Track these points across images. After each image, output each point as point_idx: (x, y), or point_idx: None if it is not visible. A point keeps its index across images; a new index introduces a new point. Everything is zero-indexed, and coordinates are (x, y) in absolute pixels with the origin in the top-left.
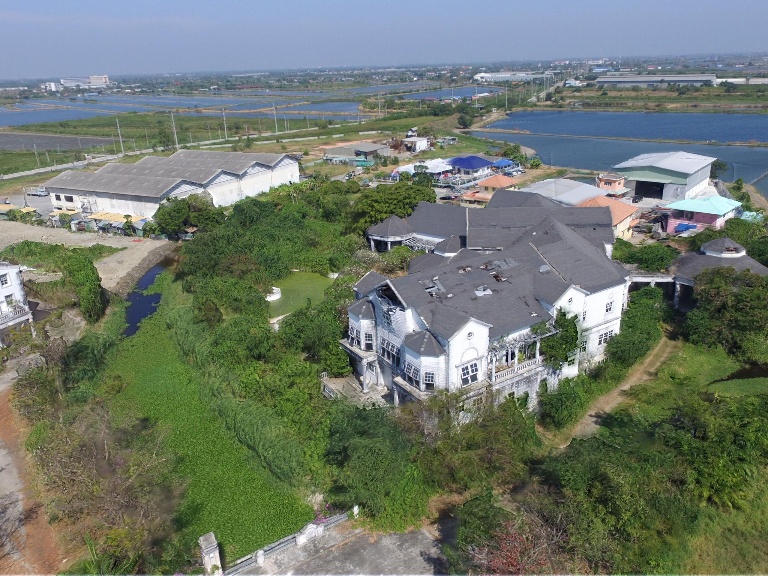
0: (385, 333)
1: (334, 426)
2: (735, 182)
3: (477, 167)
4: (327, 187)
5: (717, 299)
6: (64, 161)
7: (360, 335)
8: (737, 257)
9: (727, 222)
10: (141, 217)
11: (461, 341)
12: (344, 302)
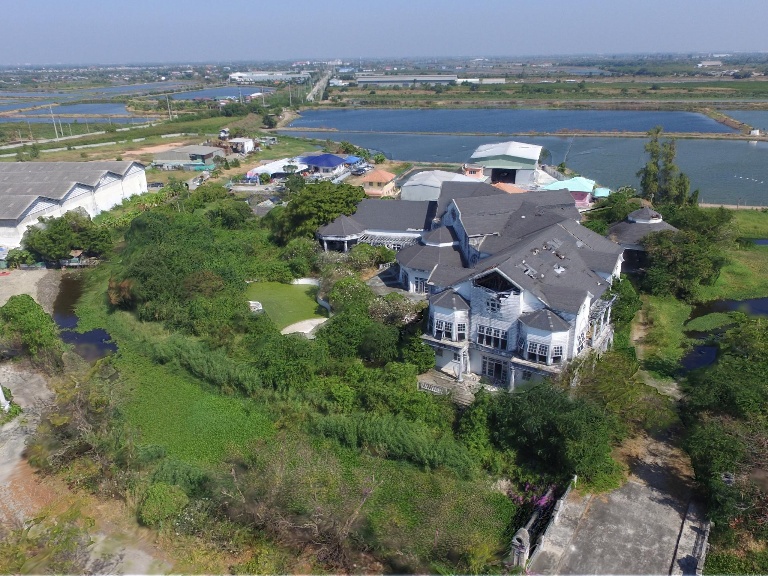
0: (485, 320)
1: (498, 413)
2: (559, 165)
3: (335, 165)
4: (199, 194)
5: (670, 256)
6: None
7: (452, 327)
8: (659, 222)
9: (611, 197)
10: None
11: (581, 313)
12: (373, 302)
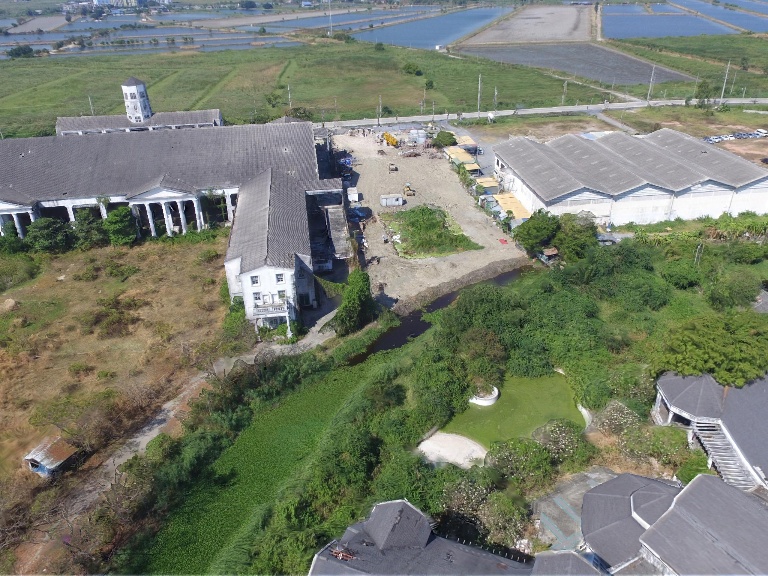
0: None
1: None
2: None
3: None
4: None
5: None
6: (590, 101)
7: None
8: None
9: None
10: (528, 215)
11: None
12: (459, 483)
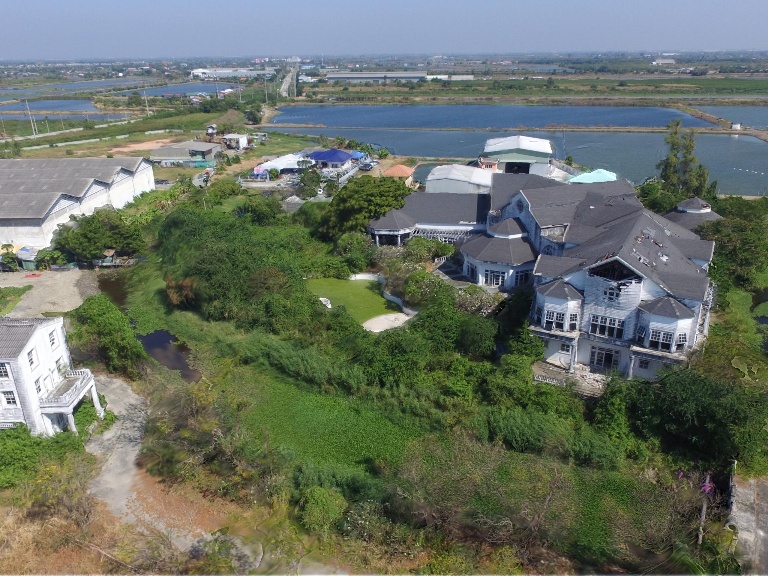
0: (599, 309)
1: (639, 401)
2: (567, 159)
3: (344, 160)
4: (216, 190)
5: (731, 244)
6: None
7: (565, 317)
8: (710, 211)
9: (644, 188)
10: (16, 246)
11: None
12: (459, 295)
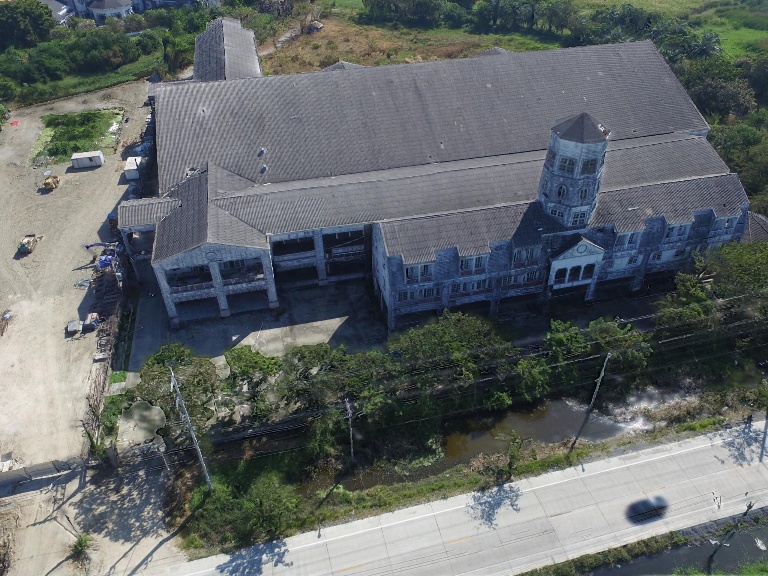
0: None
1: None
2: None
3: None
4: None
5: None
6: None
7: None
8: None
9: None
10: None
11: None
12: (161, 10)
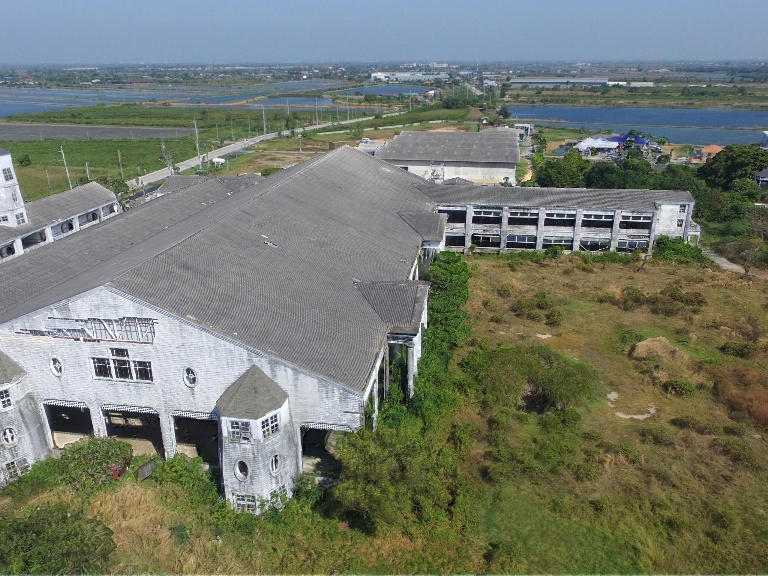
0: None
1: None
2: None
3: (645, 143)
4: (579, 157)
5: None
6: (210, 147)
7: None
8: None
9: None
10: None
11: None
12: None
